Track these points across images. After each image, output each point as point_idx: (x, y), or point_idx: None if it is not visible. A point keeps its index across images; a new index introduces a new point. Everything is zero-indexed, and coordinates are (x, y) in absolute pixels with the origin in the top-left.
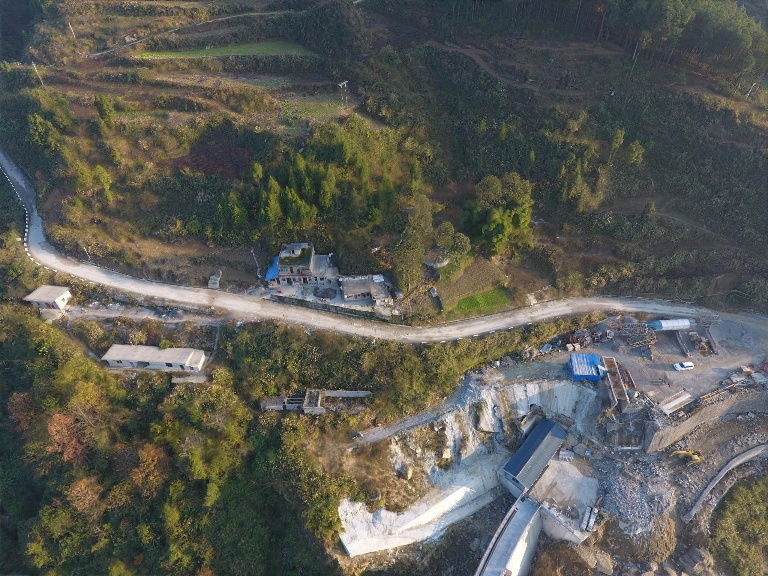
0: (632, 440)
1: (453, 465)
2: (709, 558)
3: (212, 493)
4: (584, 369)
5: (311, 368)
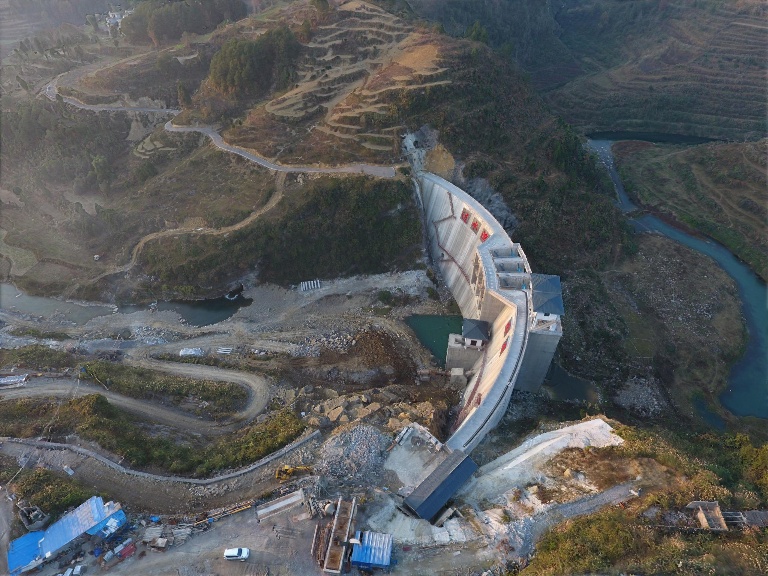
0: (340, 488)
1: (523, 486)
2: (314, 419)
3: (747, 450)
4: (378, 541)
5: (743, 545)
